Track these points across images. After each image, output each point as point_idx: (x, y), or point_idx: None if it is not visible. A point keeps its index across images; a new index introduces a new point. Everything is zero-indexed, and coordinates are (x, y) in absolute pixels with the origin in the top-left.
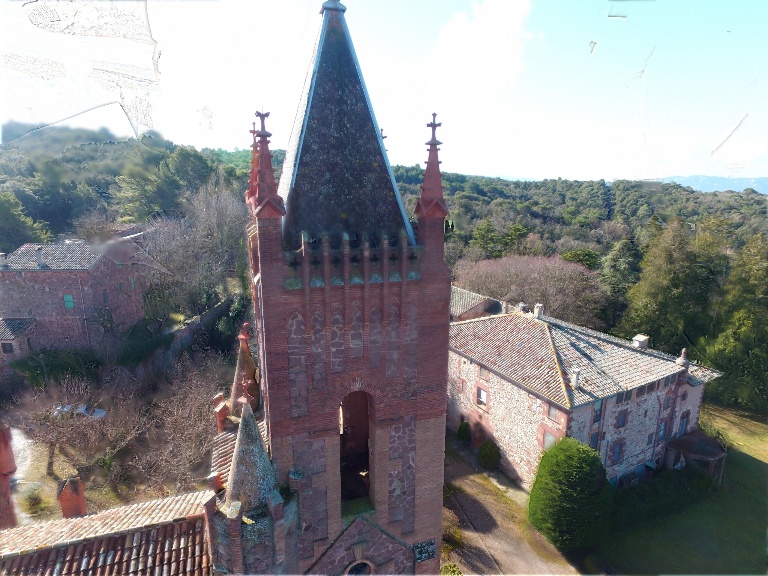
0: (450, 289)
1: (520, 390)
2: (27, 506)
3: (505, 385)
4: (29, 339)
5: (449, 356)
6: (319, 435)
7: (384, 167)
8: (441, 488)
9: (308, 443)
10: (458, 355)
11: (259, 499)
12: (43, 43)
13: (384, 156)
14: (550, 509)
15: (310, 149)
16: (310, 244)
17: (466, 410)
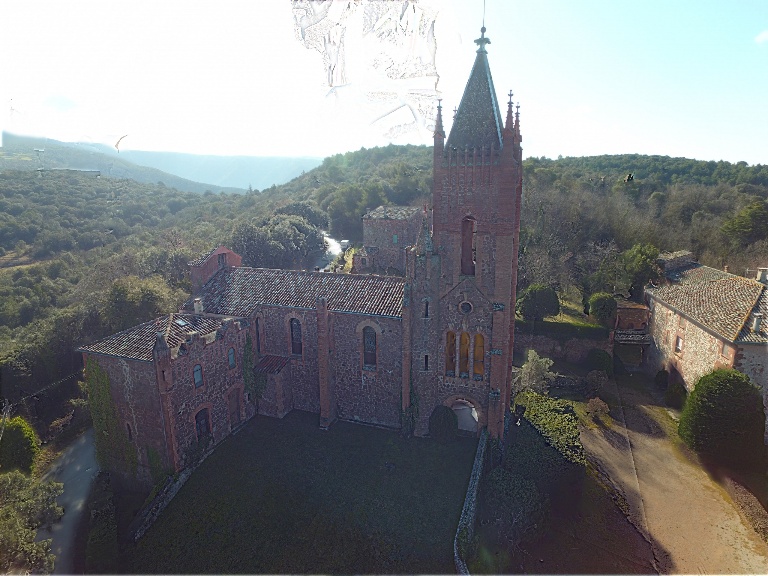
0: (515, 171)
1: (705, 333)
2: None
3: (695, 330)
4: (374, 259)
5: (660, 311)
6: (451, 233)
7: (494, 117)
8: (509, 275)
9: (447, 236)
10: (666, 308)
11: (424, 252)
12: (390, 85)
13: (494, 112)
14: (690, 417)
15: (462, 112)
16: (454, 149)
17: (667, 359)
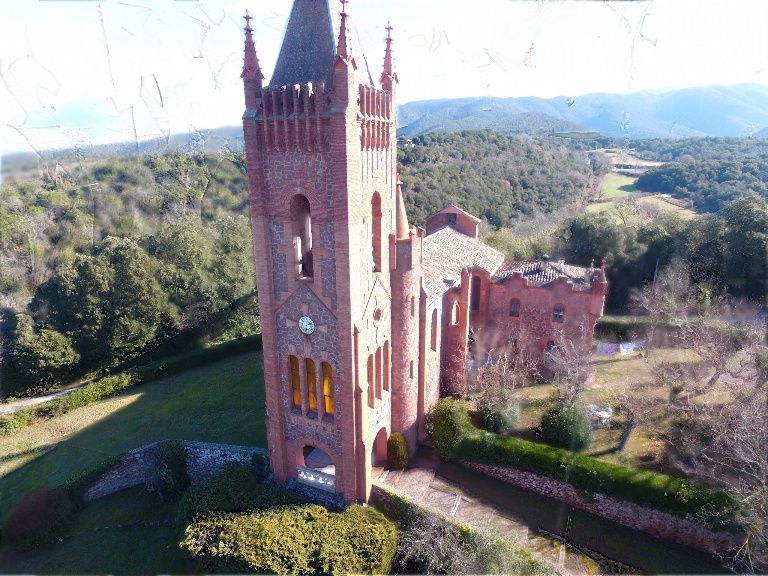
0: None
1: None
2: (650, 381)
3: None
4: None
5: None
6: None
7: None
8: None
9: None
10: None
11: None
12: None
13: None
14: None
15: None
16: None
17: None
